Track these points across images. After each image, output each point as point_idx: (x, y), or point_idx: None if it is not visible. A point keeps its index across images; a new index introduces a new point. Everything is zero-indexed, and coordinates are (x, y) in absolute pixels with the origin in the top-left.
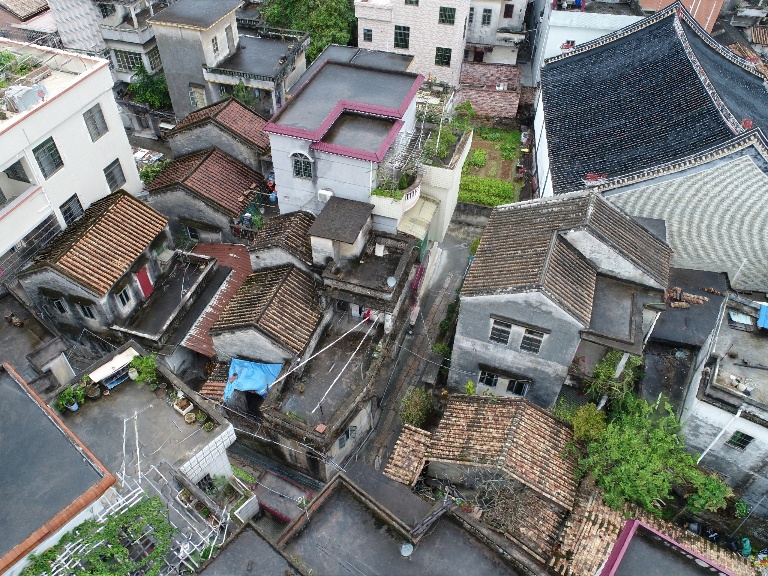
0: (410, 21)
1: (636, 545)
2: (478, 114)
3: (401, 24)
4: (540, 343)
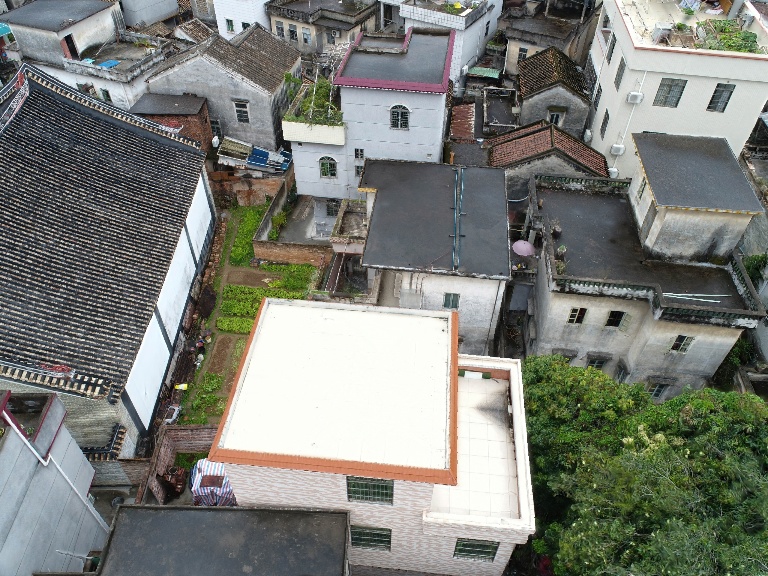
0: None
1: None
2: None
3: None
4: None
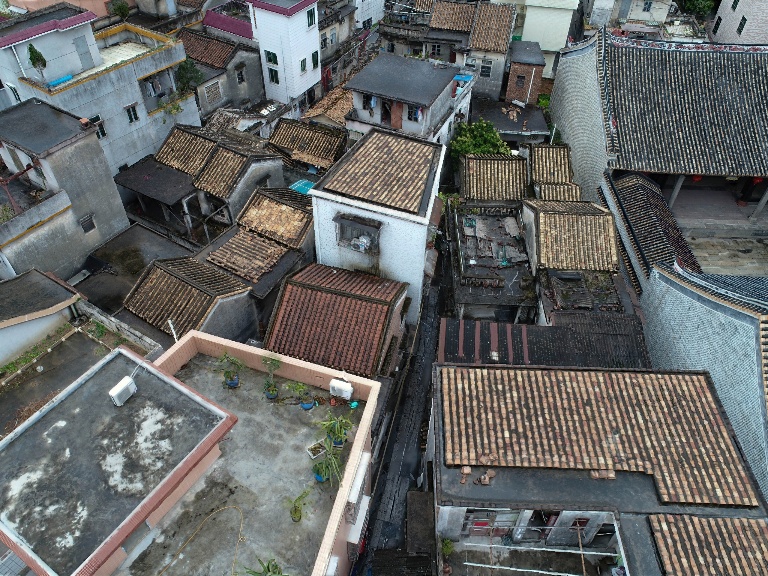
0: None
1: None
2: None
3: None
4: None
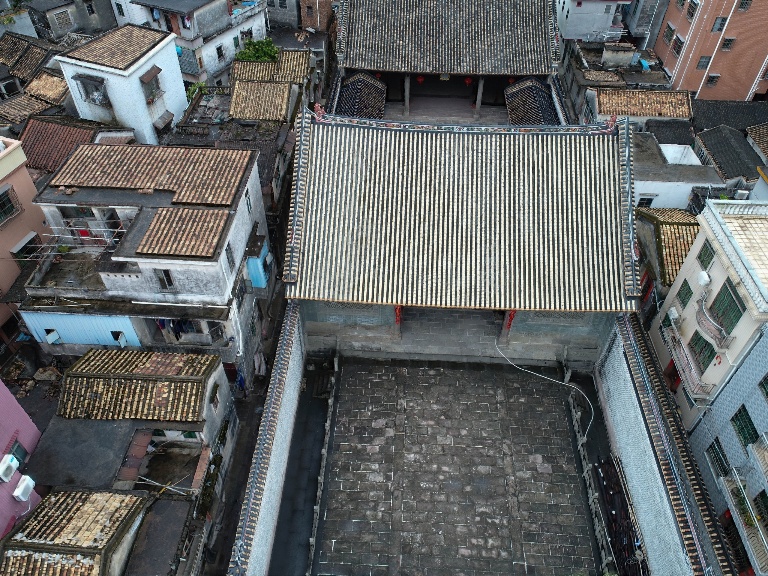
0: None
1: None
2: None
3: None
4: None
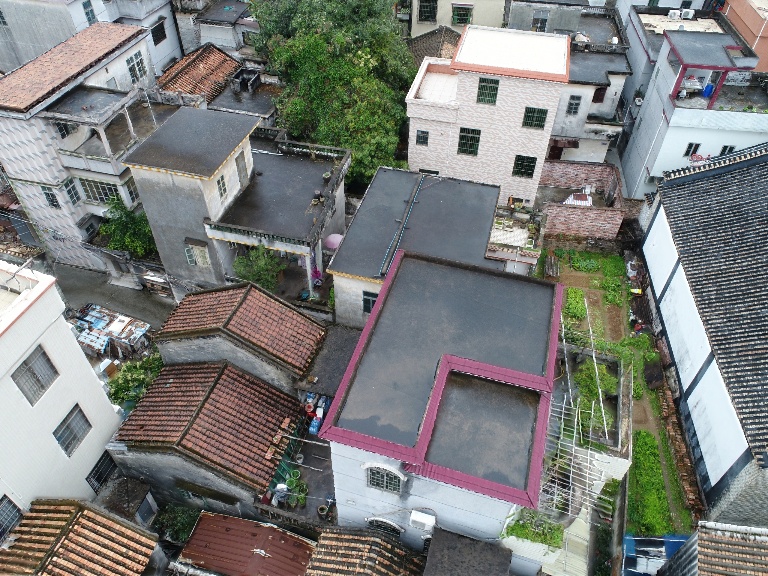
0: (482, 123)
1: None
2: (565, 234)
3: (469, 126)
4: None
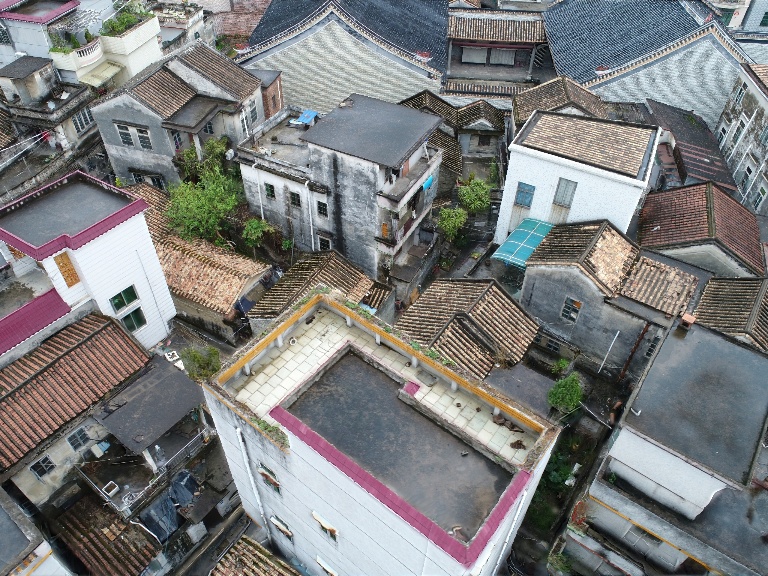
0: None
1: (76, 184)
2: (240, 35)
3: None
4: (149, 140)
